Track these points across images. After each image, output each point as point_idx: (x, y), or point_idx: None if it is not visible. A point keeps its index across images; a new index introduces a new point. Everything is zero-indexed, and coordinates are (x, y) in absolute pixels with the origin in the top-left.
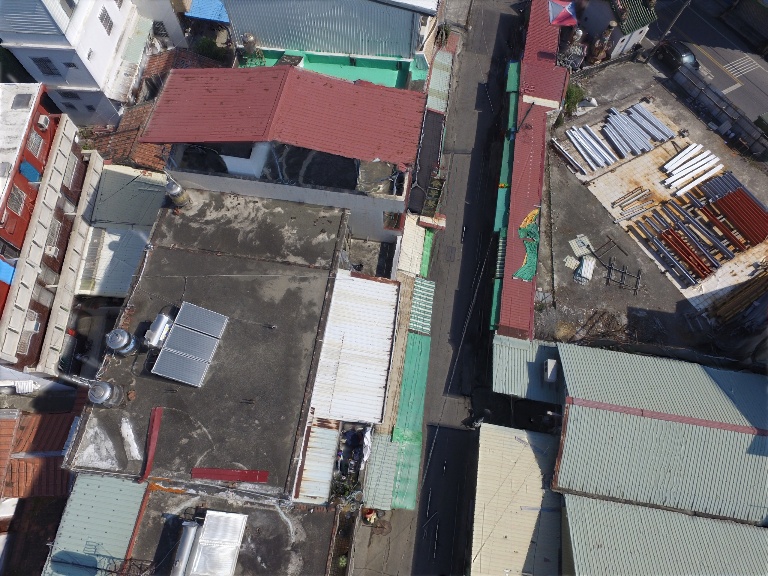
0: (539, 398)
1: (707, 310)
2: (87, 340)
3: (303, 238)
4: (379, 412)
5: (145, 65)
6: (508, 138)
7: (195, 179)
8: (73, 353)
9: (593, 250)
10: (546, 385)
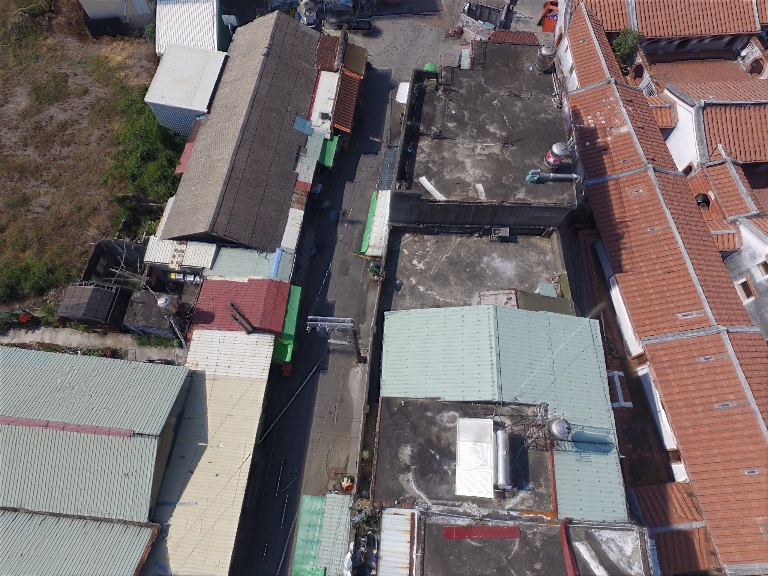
0: None
1: None
2: None
3: None
4: None
5: None
6: None
7: None
8: None
9: None
10: None
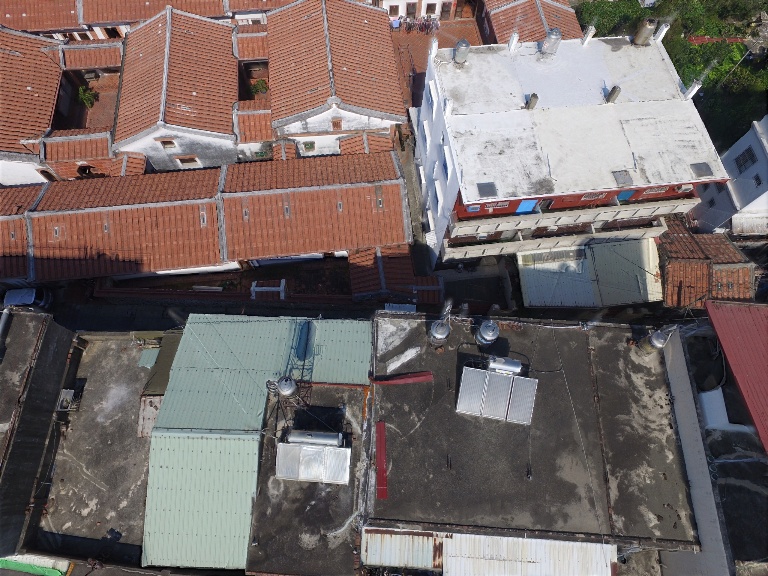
0: None
1: None
2: (476, 268)
3: (643, 493)
4: None
5: None
6: None
7: (677, 356)
8: (463, 261)
9: None
10: None
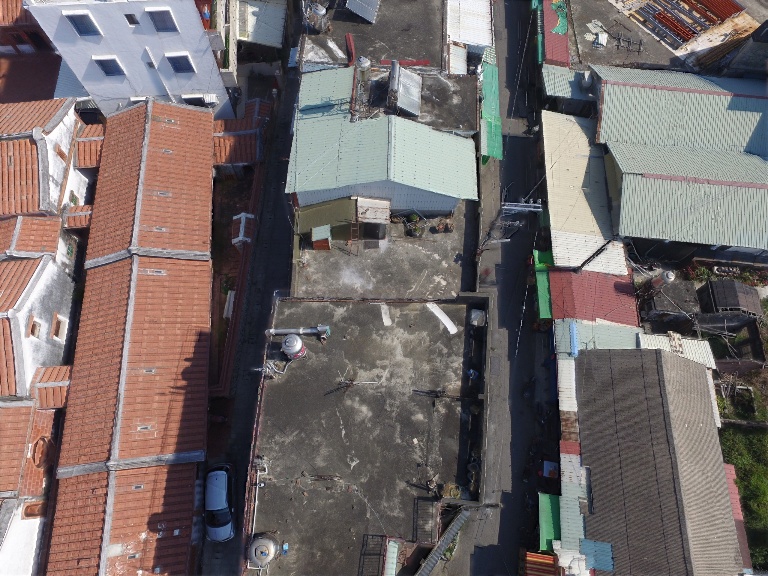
0: (580, 98)
1: (692, 62)
2: (239, 87)
3: None
4: (490, 41)
5: None
6: None
7: None
8: (233, 91)
9: (605, 29)
10: (584, 91)
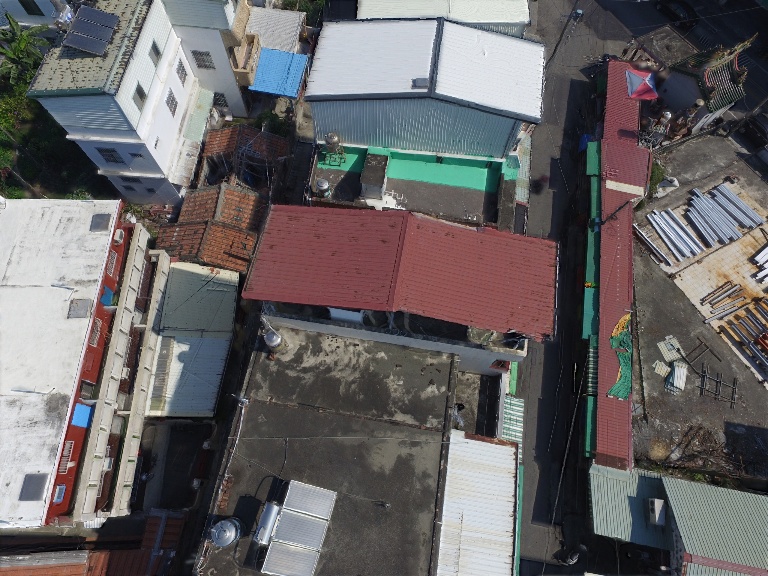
0: (645, 542)
1: None
2: (153, 456)
3: (411, 391)
4: None
5: (206, 141)
6: (592, 229)
7: (293, 323)
8: (139, 473)
9: (684, 354)
10: (651, 526)
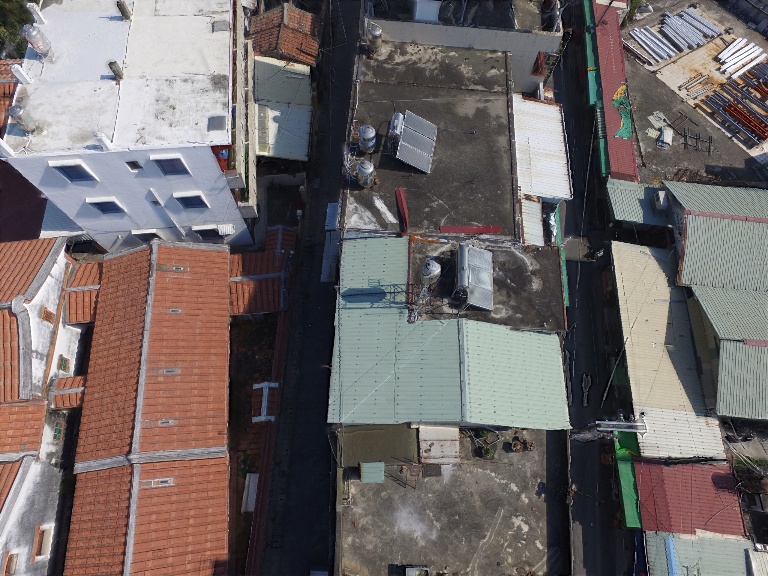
0: (654, 223)
1: None
2: None
3: (479, 73)
4: (568, 191)
5: None
6: (589, 32)
7: (386, 28)
8: None
9: (669, 123)
10: (657, 214)
